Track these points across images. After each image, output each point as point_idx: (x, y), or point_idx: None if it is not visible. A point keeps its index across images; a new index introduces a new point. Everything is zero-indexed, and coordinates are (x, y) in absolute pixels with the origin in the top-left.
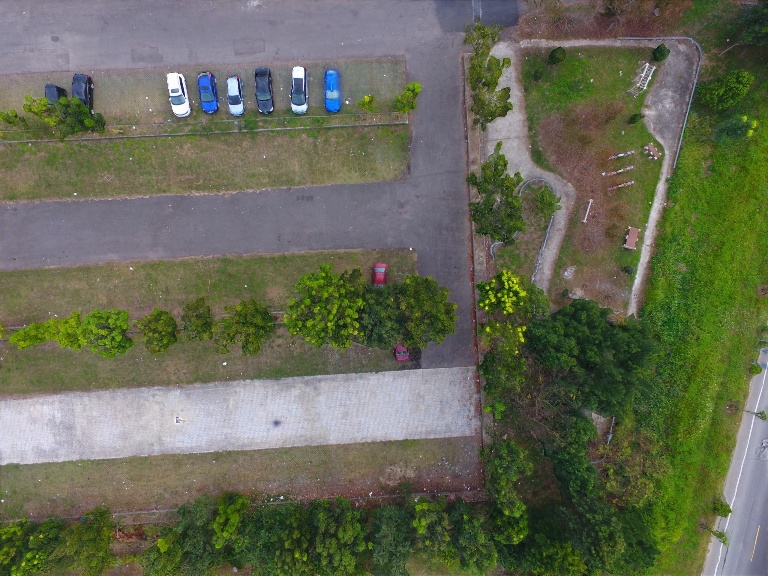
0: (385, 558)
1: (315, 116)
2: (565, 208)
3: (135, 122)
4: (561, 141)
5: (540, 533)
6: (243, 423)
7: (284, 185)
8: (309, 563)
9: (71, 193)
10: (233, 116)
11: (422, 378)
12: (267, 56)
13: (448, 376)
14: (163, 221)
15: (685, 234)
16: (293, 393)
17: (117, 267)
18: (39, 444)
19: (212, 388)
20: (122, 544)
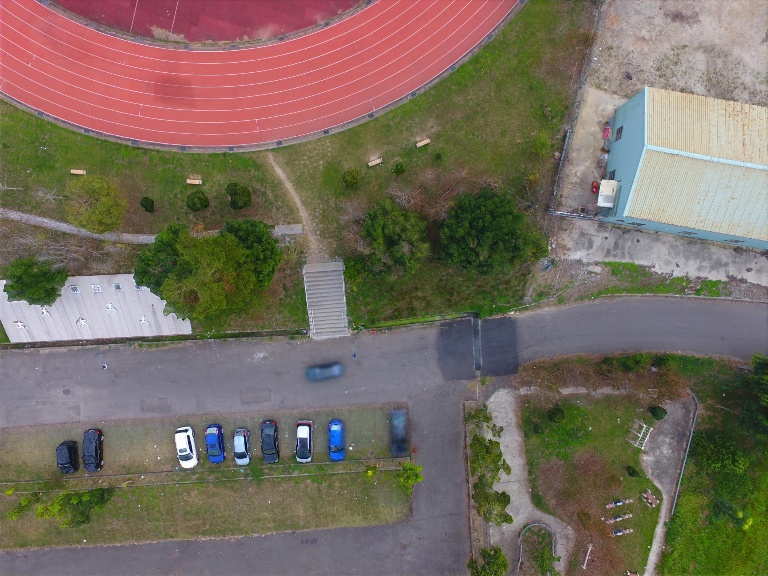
0: None
1: (319, 463)
2: (565, 550)
3: (144, 470)
4: (561, 486)
5: None
6: None
7: (289, 529)
8: None
9: (80, 540)
10: None
11: None
12: (273, 405)
13: None
14: (170, 565)
15: None
16: None
17: None
18: None
19: None
20: None
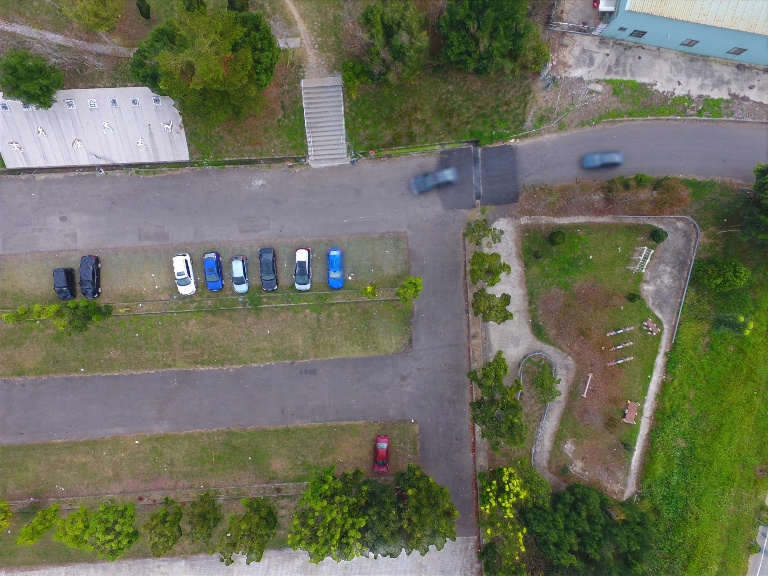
0: None
1: (318, 292)
2: (565, 381)
3: (141, 299)
4: (561, 316)
5: None
6: None
7: (288, 359)
8: None
9: (78, 369)
10: (238, 293)
11: None
12: (271, 234)
13: (449, 546)
14: (168, 395)
15: (684, 411)
16: (296, 563)
17: (123, 440)
18: None
19: (216, 559)
20: None
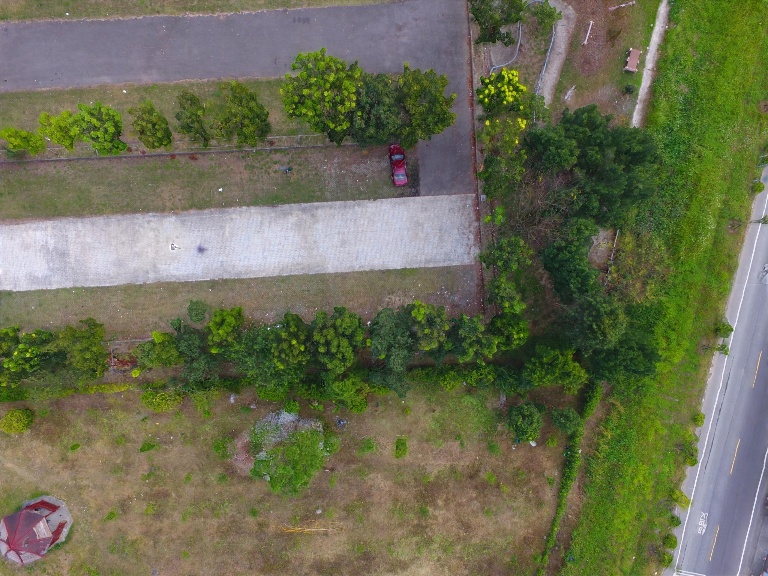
0: (383, 345)
1: None
2: (565, 31)
3: None
4: None
5: (540, 345)
6: (239, 250)
7: (280, 7)
8: (306, 355)
9: (63, 13)
10: None
11: (421, 206)
12: None
13: (447, 204)
14: (157, 43)
15: (687, 54)
16: (290, 220)
17: (110, 90)
18: (32, 271)
19: (208, 215)
20: (117, 373)
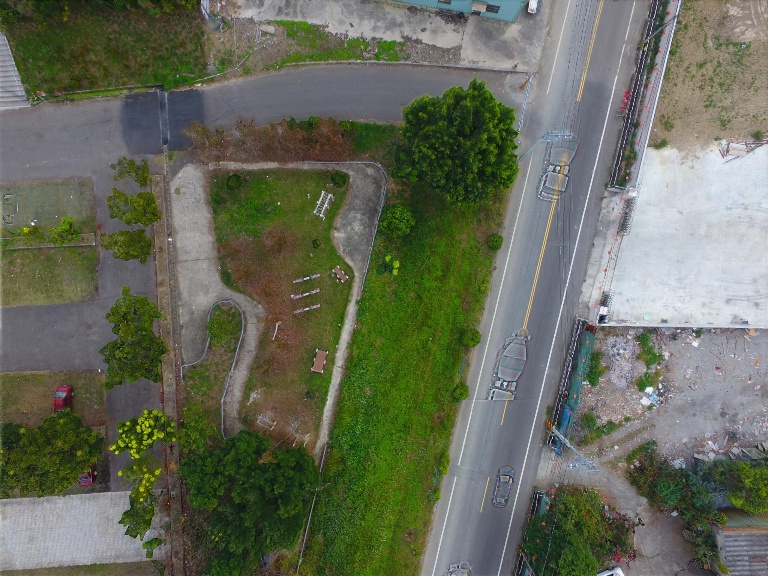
0: None
1: None
2: (255, 329)
3: None
4: (250, 263)
5: None
6: None
7: None
8: None
9: None
10: None
11: (111, 501)
12: None
13: None
14: None
15: (369, 358)
16: None
17: None
18: None
19: None
20: None
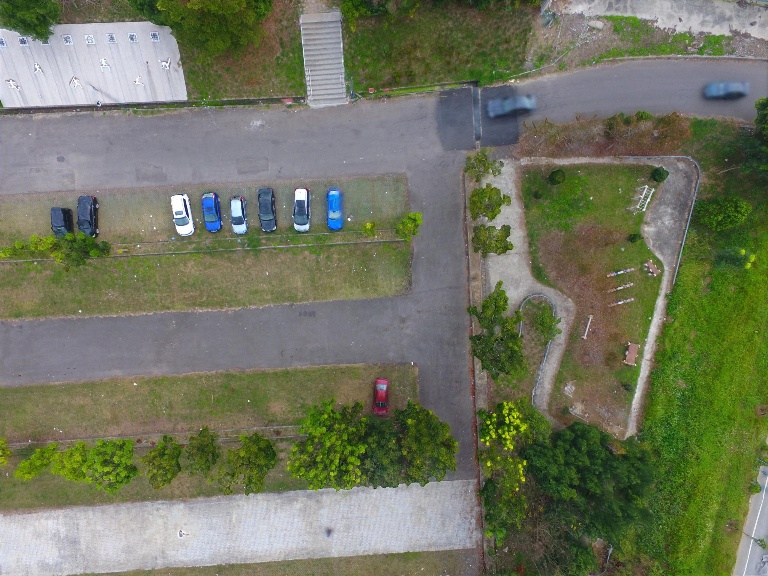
0: None
1: (317, 233)
2: (565, 323)
3: (139, 240)
4: (561, 257)
5: None
6: (246, 536)
7: (287, 301)
8: None
9: (76, 310)
10: (236, 234)
11: (423, 491)
12: (270, 175)
13: (449, 489)
14: (167, 337)
15: (684, 351)
16: (295, 506)
17: (121, 383)
18: (44, 558)
19: (215, 502)
20: None
